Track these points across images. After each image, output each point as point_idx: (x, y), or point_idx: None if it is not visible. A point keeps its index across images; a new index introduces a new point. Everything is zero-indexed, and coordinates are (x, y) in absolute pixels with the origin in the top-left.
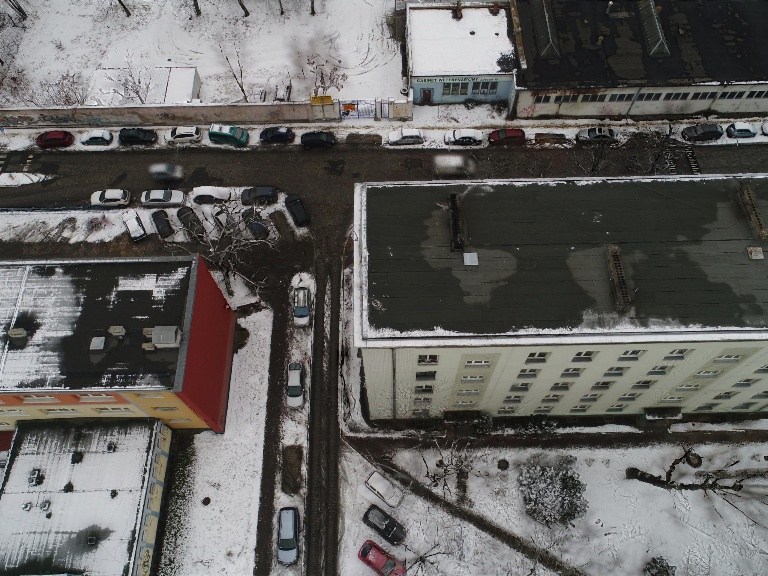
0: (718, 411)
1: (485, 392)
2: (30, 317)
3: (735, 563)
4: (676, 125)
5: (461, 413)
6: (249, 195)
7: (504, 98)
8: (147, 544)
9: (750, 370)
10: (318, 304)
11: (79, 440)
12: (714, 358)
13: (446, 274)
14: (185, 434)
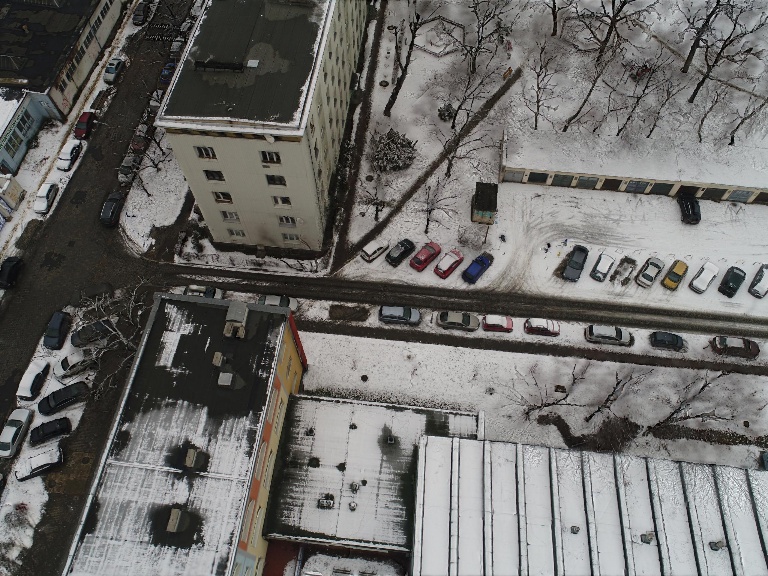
0: None
1: None
2: (174, 453)
3: (445, 82)
4: (126, 26)
5: (331, 185)
6: (53, 337)
7: (40, 118)
8: None
9: (349, 2)
10: None
11: (297, 463)
12: None
13: (260, 78)
14: None
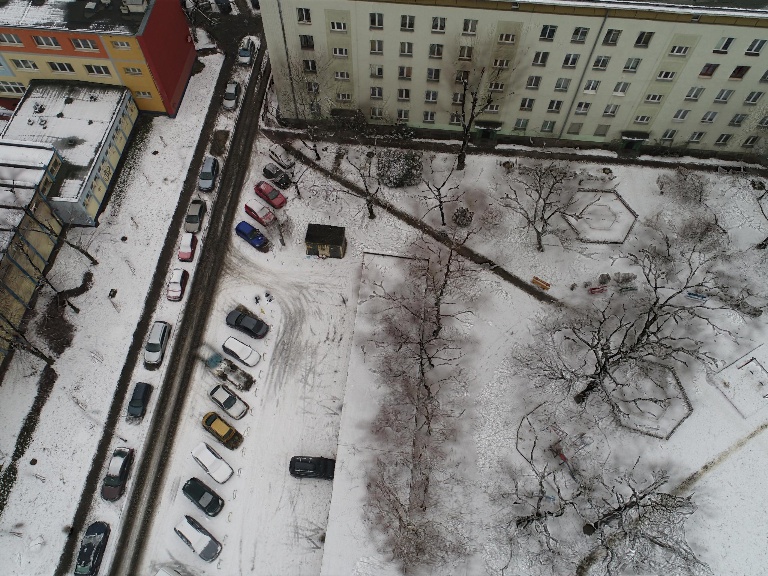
0: (532, 135)
1: (353, 77)
2: None
3: (519, 220)
4: None
5: (343, 112)
6: None
7: None
8: (109, 162)
9: (528, 61)
10: (259, 55)
11: (72, 92)
12: (496, 37)
13: None
14: (148, 116)
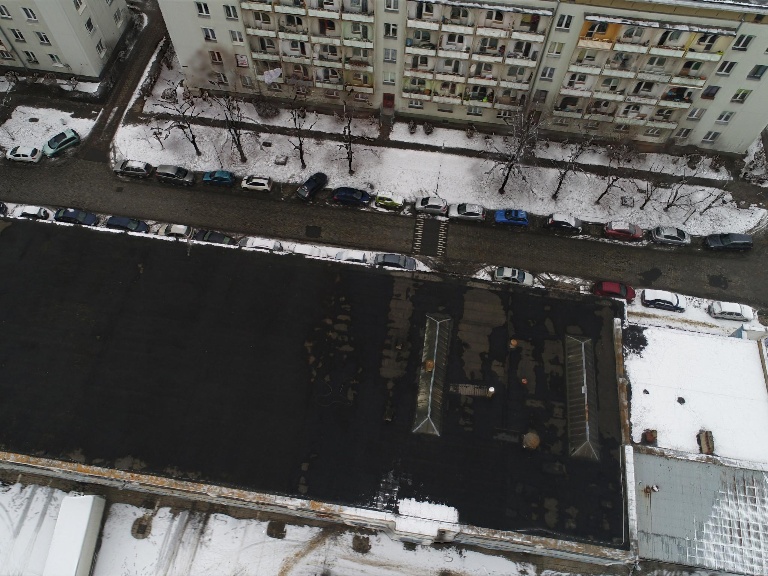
0: None
1: None
2: None
3: None
4: None
5: None
6: None
7: None
8: None
9: None
10: None
11: None
12: None
13: None
14: None
